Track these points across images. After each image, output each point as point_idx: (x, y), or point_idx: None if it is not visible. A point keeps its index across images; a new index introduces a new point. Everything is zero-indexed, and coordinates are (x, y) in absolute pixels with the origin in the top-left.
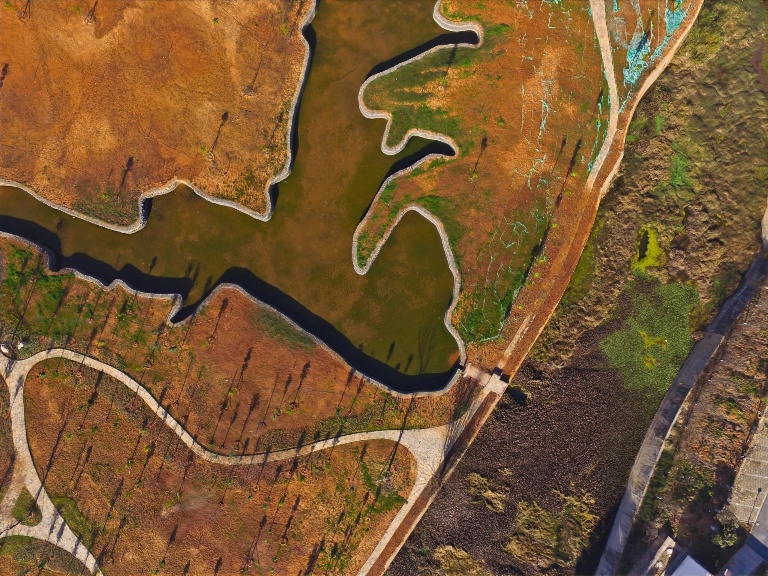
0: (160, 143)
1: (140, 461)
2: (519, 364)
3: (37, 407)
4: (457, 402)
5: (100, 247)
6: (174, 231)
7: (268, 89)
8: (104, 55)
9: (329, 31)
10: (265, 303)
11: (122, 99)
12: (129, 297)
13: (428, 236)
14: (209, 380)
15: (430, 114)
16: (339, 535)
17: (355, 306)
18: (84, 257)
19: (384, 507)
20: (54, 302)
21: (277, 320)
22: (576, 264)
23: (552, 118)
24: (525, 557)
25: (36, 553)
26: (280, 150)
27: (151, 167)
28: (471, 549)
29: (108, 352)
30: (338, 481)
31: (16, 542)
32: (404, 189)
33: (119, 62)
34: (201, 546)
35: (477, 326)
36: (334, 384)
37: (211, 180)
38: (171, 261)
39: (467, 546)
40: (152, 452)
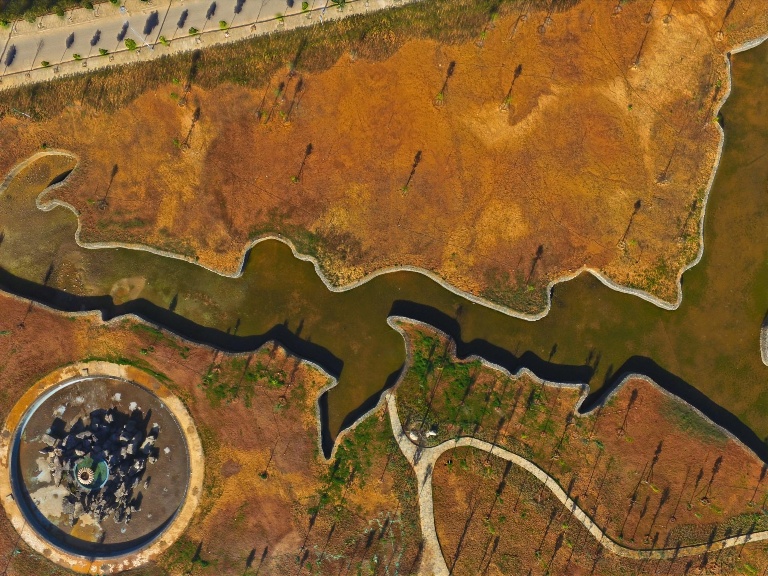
0: (571, 231)
1: (548, 553)
2: None
3: (445, 495)
4: None
5: (500, 333)
6: (575, 318)
7: (681, 177)
8: (517, 142)
9: (737, 116)
10: (675, 395)
11: (534, 187)
12: (536, 386)
13: None
14: (618, 472)
15: None
16: None
17: (761, 398)
18: (483, 343)
19: None
20: (461, 390)
21: (688, 413)
22: None
23: None
24: None
25: None
26: (693, 239)
27: (561, 255)
28: None
29: (516, 442)
30: None
31: None
32: None
33: (532, 149)
34: None
35: None
36: (747, 480)
37: (621, 269)
38: (571, 349)
39: None
40: (560, 544)
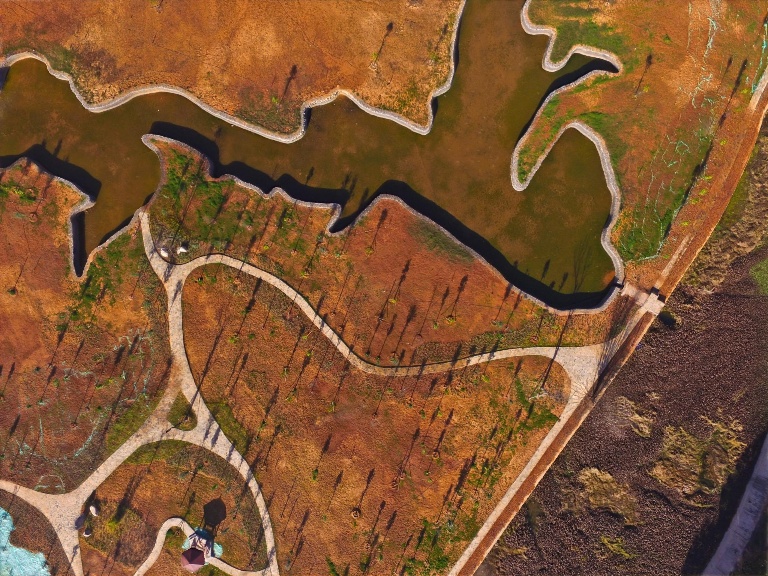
0: (324, 52)
1: (296, 369)
2: (675, 285)
3: (195, 312)
4: (614, 321)
5: (258, 156)
6: (332, 142)
7: (433, 1)
8: None
9: None
10: (424, 215)
11: (288, 6)
12: (288, 205)
13: (586, 154)
14: (366, 291)
15: (595, 30)
16: (491, 451)
17: (511, 223)
18: (241, 166)
19: (536, 424)
20: (214, 208)
21: (436, 233)
22: (735, 186)
23: (719, 37)
24: (670, 483)
25: (190, 458)
26: (443, 62)
27: (314, 76)
28: (616, 473)
29: (267, 259)
30: (492, 396)
31: (171, 446)
32: (567, 105)
33: None
34: (354, 456)
35: (636, 245)
36: (491, 298)
37: (374, 90)
38: (328, 172)
39: (612, 469)
40: (308, 361)
